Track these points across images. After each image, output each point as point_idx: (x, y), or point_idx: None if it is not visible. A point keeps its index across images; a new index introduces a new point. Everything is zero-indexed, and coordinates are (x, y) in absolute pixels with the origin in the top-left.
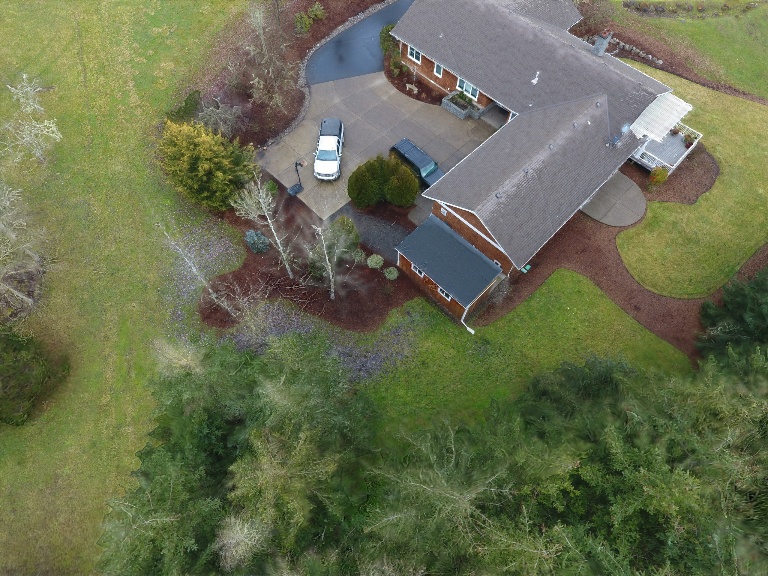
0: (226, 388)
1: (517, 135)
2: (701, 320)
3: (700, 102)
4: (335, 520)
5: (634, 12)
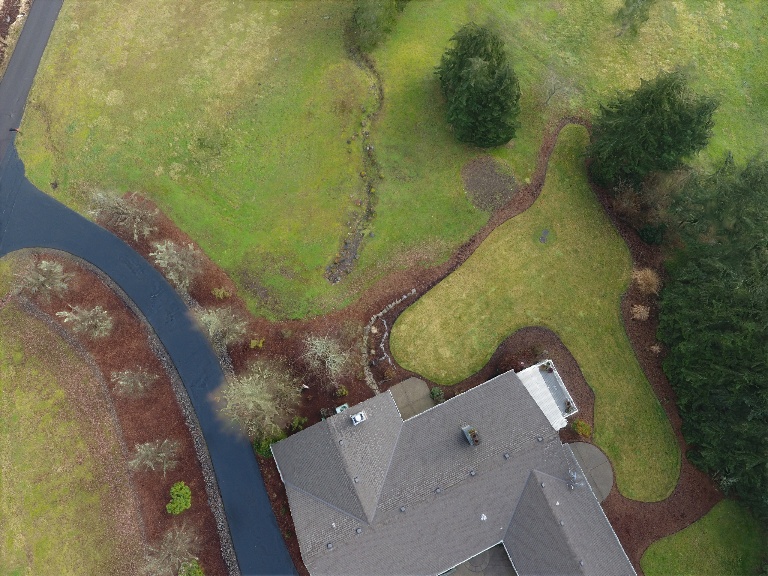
0: None
1: (540, 570)
2: (701, 470)
3: (473, 290)
4: None
5: (341, 272)
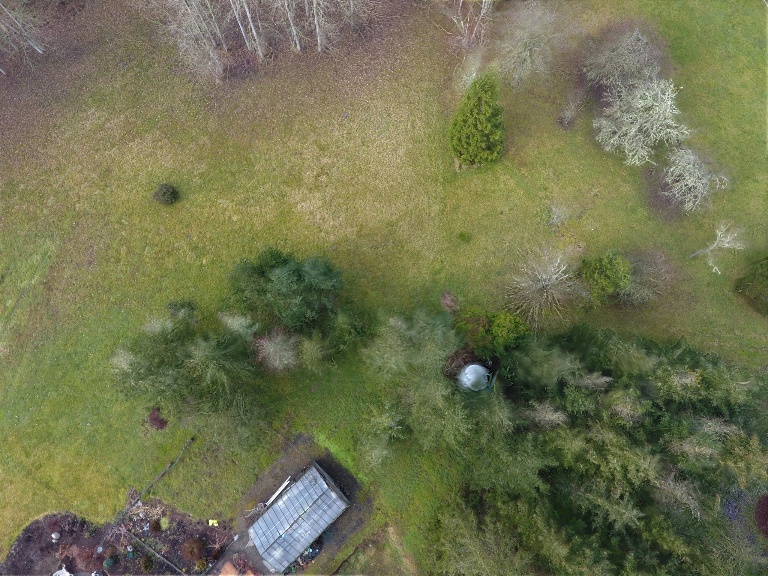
0: (767, 425)
1: None
2: None
3: None
4: (696, 472)
5: None
